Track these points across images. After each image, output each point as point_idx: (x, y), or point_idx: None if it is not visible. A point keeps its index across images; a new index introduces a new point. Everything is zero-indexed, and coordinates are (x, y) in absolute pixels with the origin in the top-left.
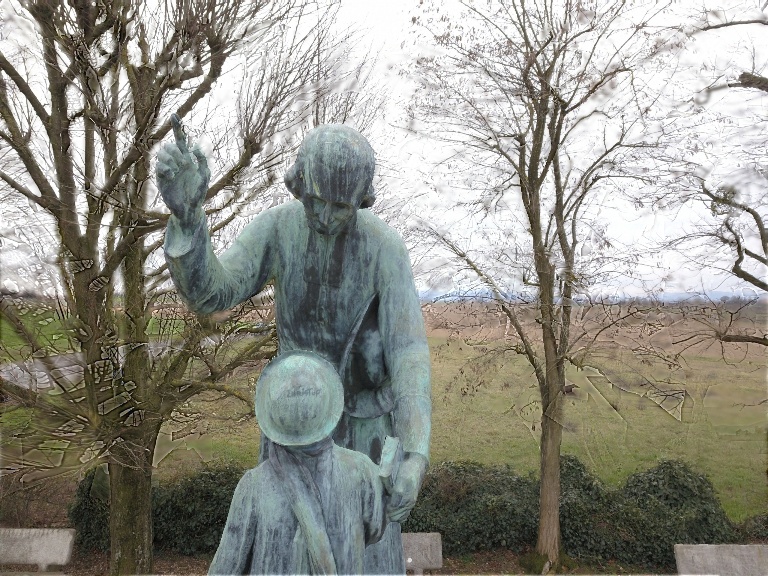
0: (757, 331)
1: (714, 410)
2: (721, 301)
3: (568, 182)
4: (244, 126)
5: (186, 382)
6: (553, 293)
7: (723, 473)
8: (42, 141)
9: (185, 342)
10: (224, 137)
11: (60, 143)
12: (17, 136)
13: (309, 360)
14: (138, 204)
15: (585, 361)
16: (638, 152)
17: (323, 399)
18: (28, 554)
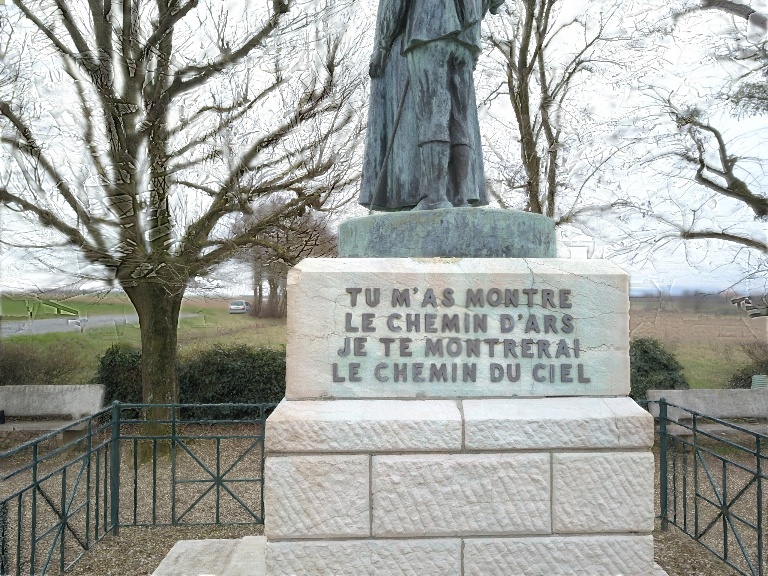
0: (716, 227)
1: (679, 298)
2: (685, 206)
3: (551, 86)
4: None
5: (212, 241)
6: (538, 181)
7: (687, 353)
8: (82, 8)
9: (223, 178)
10: None
11: (99, 10)
12: (60, 1)
13: None
14: None
15: (570, 218)
16: (614, 46)
17: None
18: (62, 406)
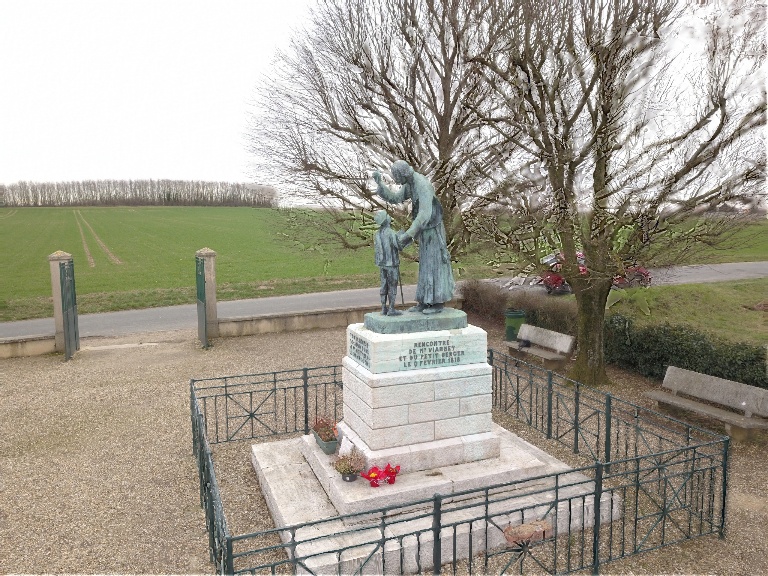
0: None
1: None
2: None
3: None
4: (601, 98)
5: None
6: None
7: None
8: None
9: None
10: (699, 77)
11: None
12: None
13: None
14: None
15: None
16: None
17: (379, 217)
18: (554, 344)
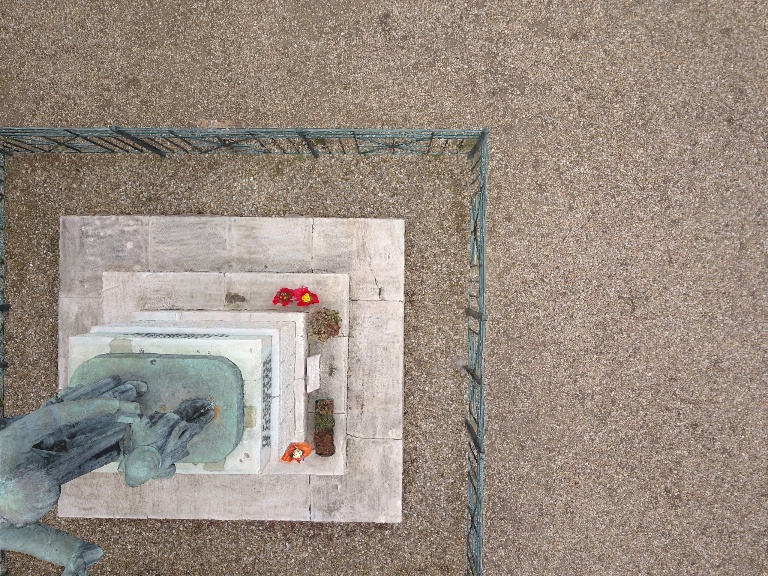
0: None
1: None
2: None
3: None
4: None
5: None
6: None
7: None
8: None
9: None
10: None
11: None
12: None
13: (139, 467)
14: None
15: None
16: None
17: None
18: None
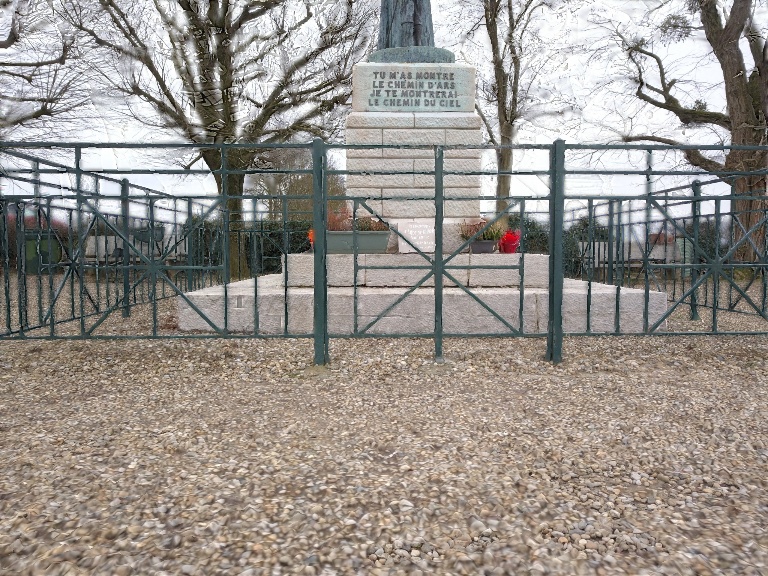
0: (648, 131)
1: (618, 187)
2: None
3: None
4: None
5: (268, 130)
6: (506, 92)
7: None
8: None
9: None
10: None
11: None
12: None
13: None
14: (235, 8)
15: (522, 113)
16: None
17: None
18: None
